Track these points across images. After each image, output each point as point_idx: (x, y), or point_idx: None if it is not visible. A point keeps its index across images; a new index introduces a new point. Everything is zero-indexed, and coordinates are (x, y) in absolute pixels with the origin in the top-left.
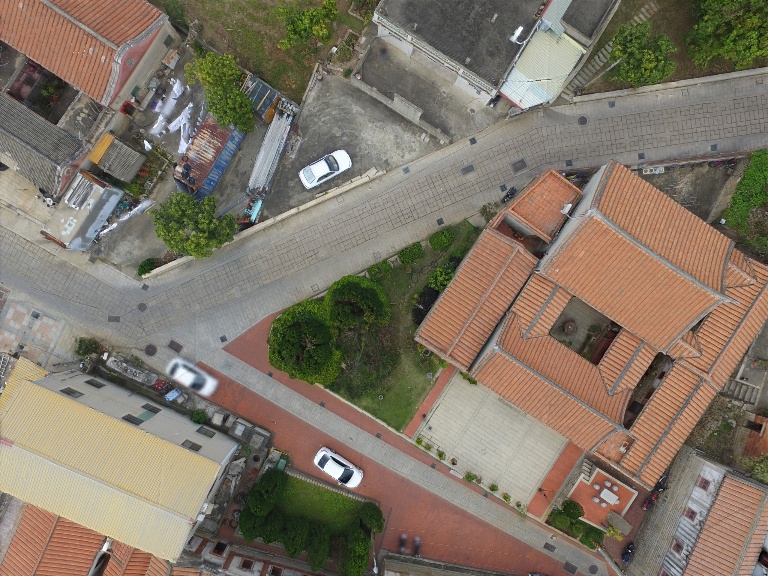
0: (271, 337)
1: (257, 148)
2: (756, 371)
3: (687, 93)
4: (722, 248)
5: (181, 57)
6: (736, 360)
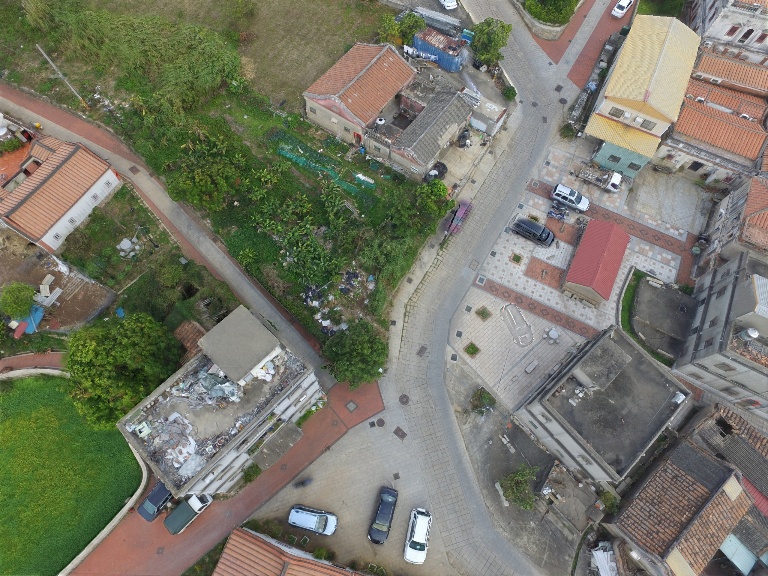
0: (552, 17)
1: None
2: None
3: None
4: None
5: None
6: None
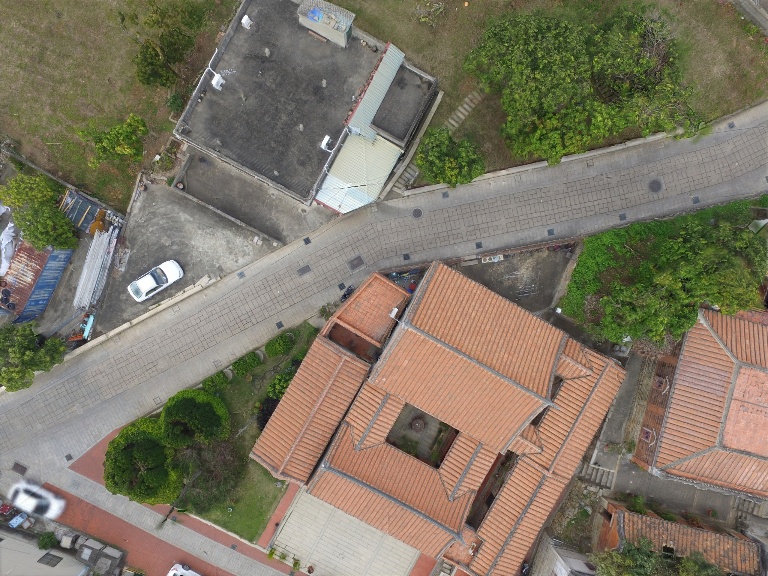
0: (105, 461)
1: None
2: (609, 455)
3: (520, 179)
4: (553, 343)
5: (2, 173)
6: (581, 451)
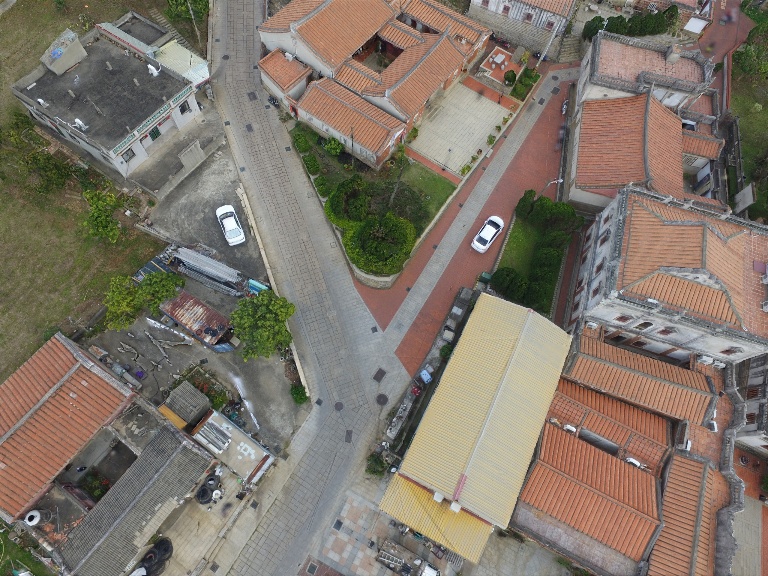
0: (372, 268)
1: (201, 287)
2: None
3: (218, 1)
4: None
5: None
6: None
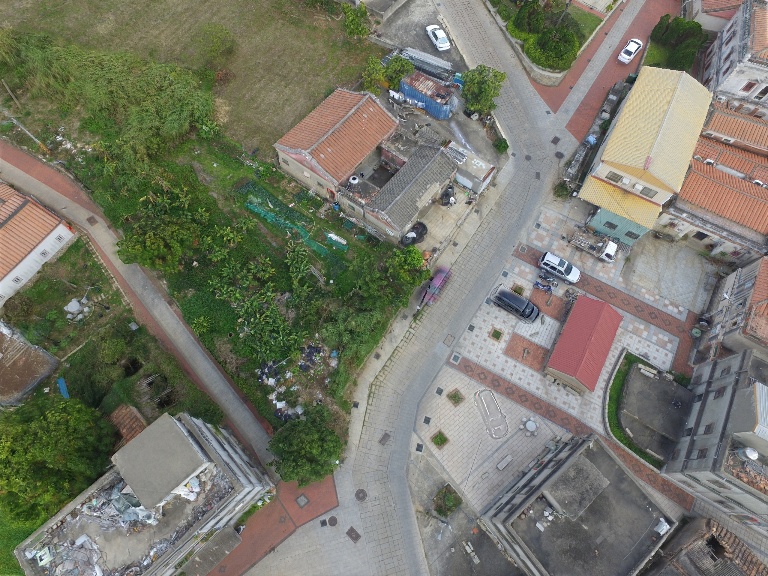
0: (551, 63)
1: None
2: None
3: None
4: None
5: None
6: None
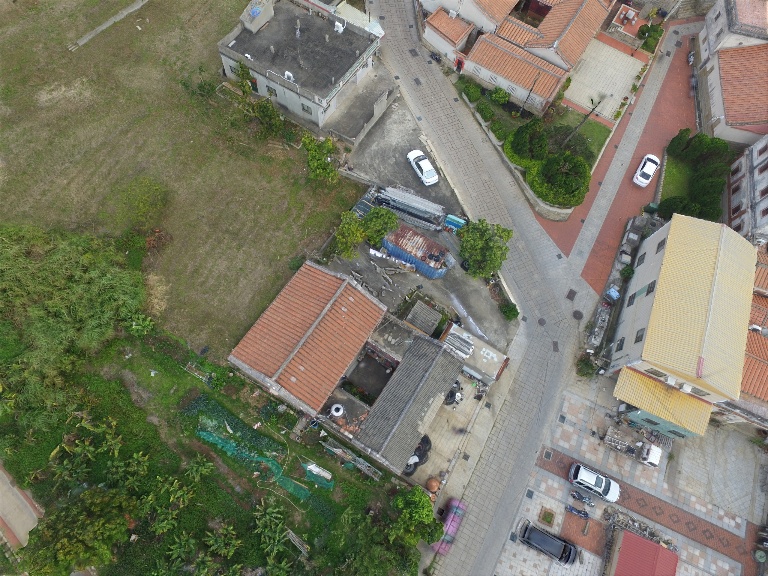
0: (561, 200)
1: None
2: None
3: None
4: None
5: None
6: None
